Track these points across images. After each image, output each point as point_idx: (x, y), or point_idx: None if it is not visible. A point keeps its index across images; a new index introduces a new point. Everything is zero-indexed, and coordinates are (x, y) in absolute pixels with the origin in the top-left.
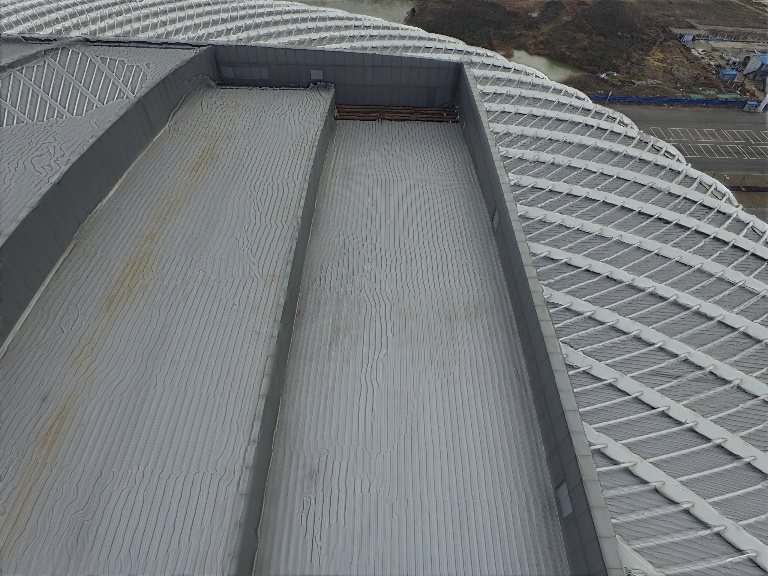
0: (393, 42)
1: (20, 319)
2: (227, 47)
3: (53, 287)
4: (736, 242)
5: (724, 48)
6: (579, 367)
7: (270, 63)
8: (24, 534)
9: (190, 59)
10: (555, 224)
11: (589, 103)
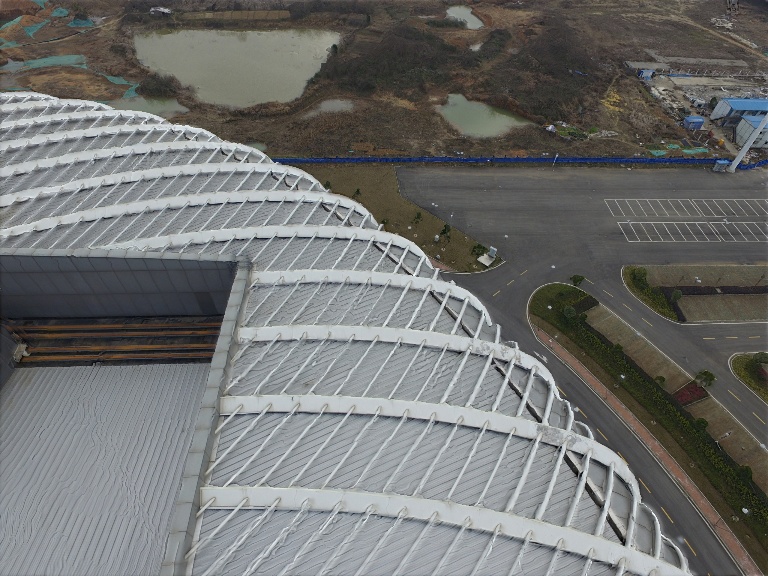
0: (147, 204)
1: None
2: None
3: None
4: None
5: (687, 85)
6: None
7: None
8: None
9: None
10: None
11: (459, 338)
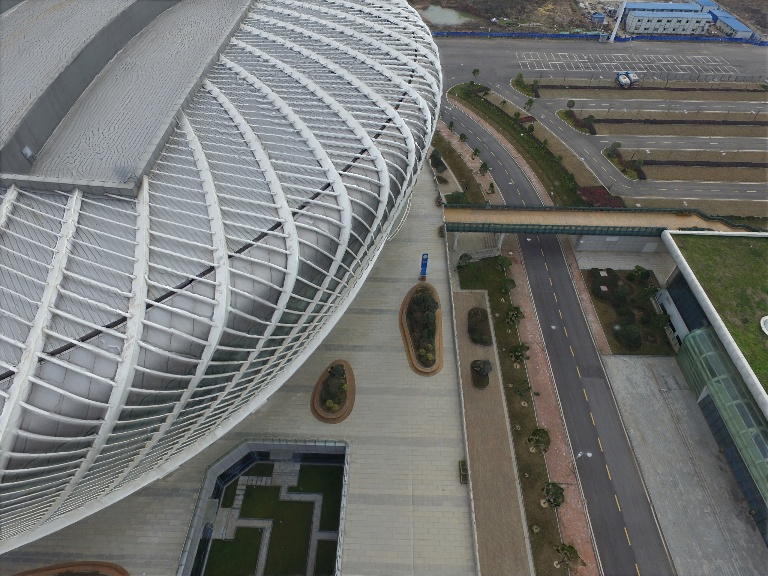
0: None
1: (8, 10)
2: None
3: (24, 5)
4: (380, 15)
5: (609, 2)
6: (246, 30)
7: None
8: (4, 39)
9: None
10: (278, 2)
11: None
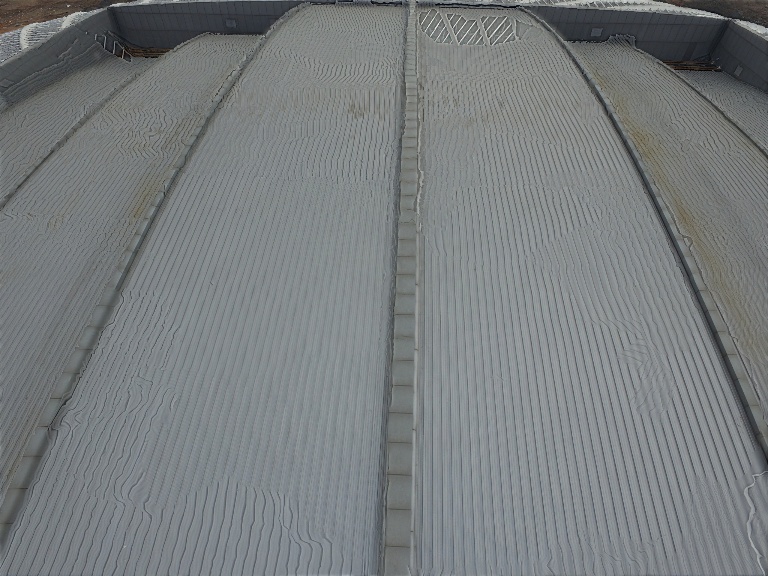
0: (650, 7)
1: None
2: (531, 8)
3: None
4: None
5: None
6: None
7: (561, 22)
8: None
9: None
10: None
11: None
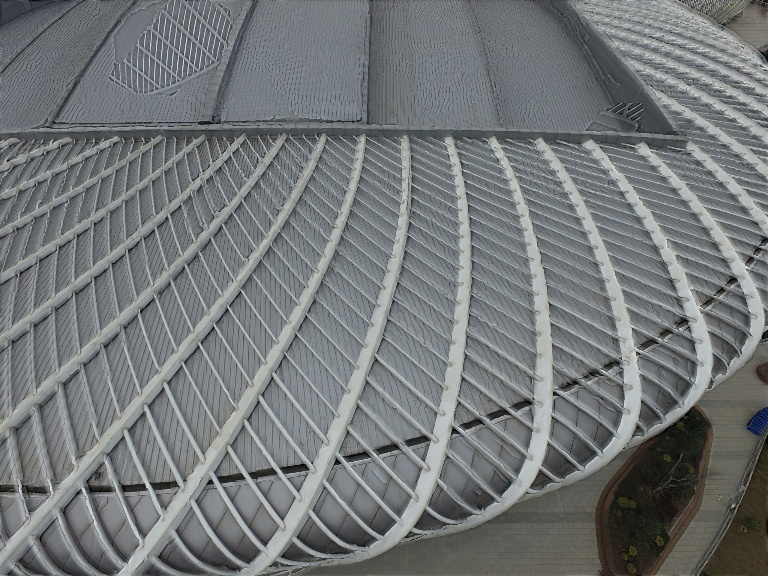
0: None
1: None
2: None
3: None
4: None
5: None
6: None
7: None
8: None
9: (73, 79)
10: None
11: None
